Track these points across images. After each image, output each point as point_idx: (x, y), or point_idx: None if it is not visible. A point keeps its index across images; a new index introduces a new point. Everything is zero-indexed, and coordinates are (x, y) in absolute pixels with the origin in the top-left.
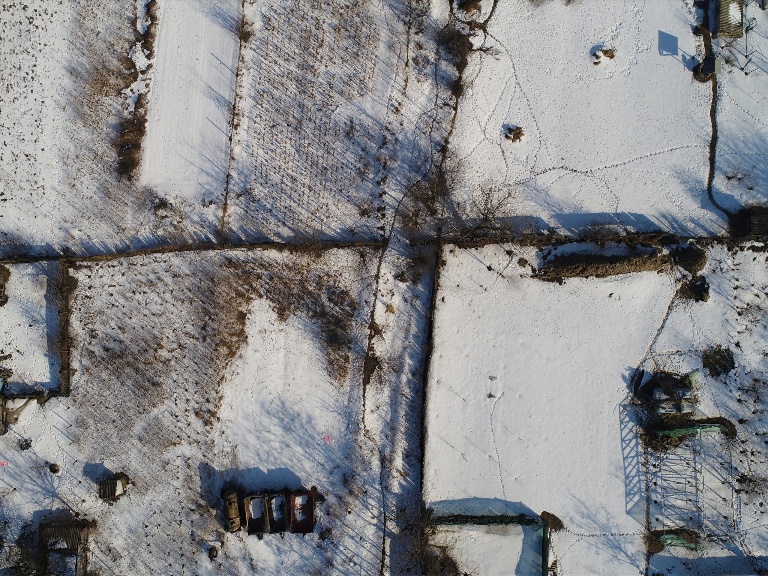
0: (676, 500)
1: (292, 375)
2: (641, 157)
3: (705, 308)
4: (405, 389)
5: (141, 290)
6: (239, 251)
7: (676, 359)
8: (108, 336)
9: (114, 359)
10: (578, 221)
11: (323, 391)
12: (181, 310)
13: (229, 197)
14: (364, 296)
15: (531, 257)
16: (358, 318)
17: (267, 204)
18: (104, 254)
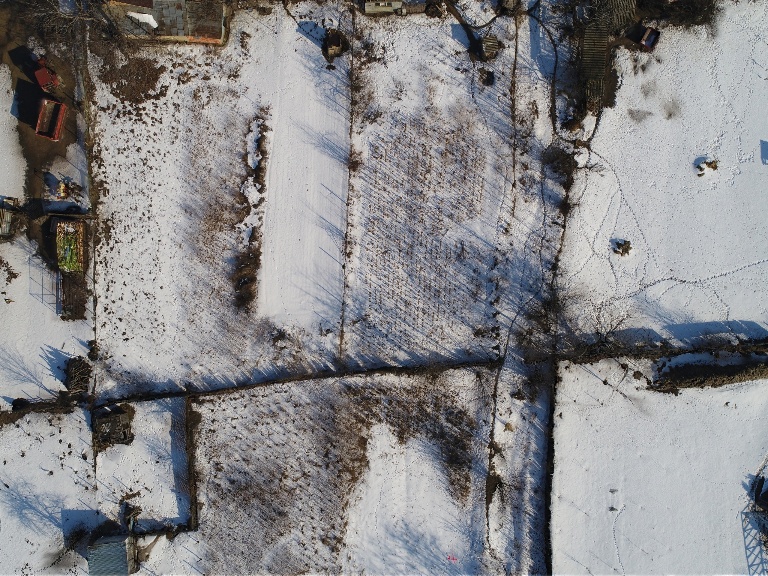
0: None
1: (414, 497)
2: (749, 265)
3: None
4: (528, 507)
5: (263, 421)
6: (358, 377)
7: None
8: (233, 468)
9: (240, 491)
10: (690, 331)
11: (446, 511)
12: (303, 439)
13: (345, 324)
14: (482, 416)
15: (646, 370)
16: (477, 438)
17: (383, 329)
18: (226, 387)
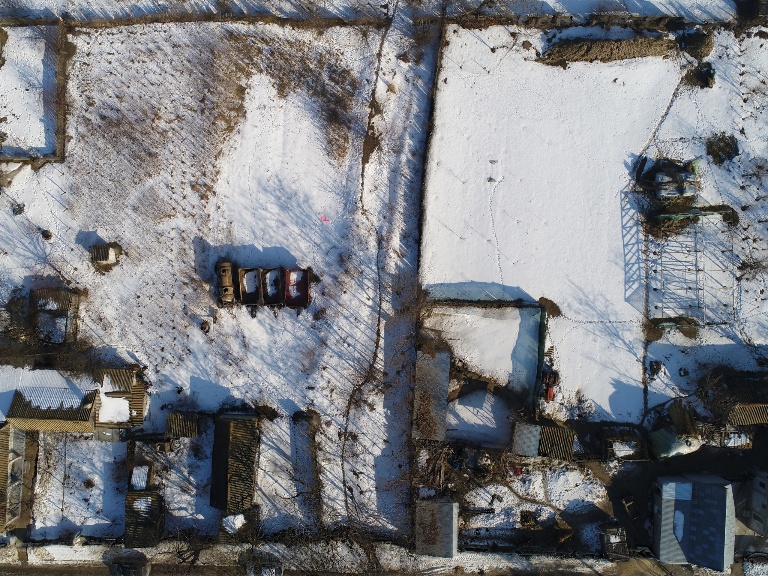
0: (676, 287)
1: (290, 153)
2: None
3: (710, 95)
4: (404, 169)
5: (140, 59)
6: (240, 24)
7: (679, 146)
8: (105, 104)
9: (111, 128)
10: (584, 6)
11: (321, 171)
12: (180, 81)
13: None
14: (365, 75)
15: (535, 40)
16: (359, 97)
17: None
18: (104, 21)
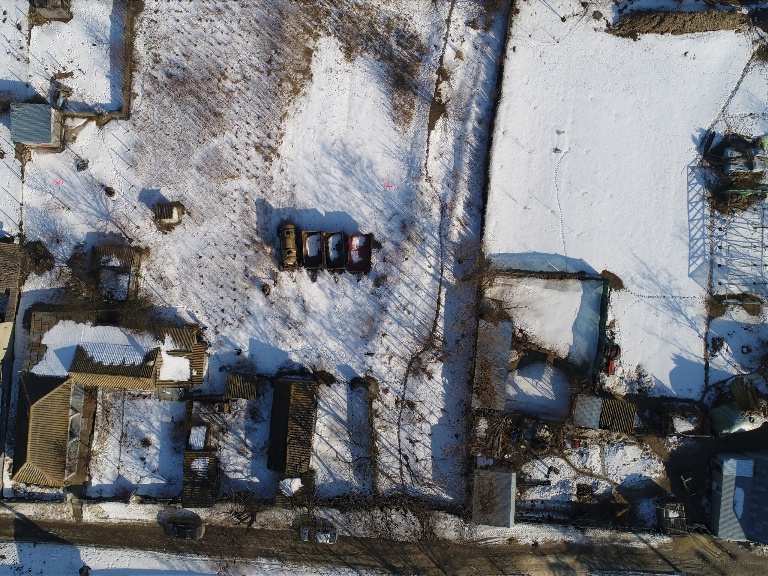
0: (741, 264)
1: (355, 118)
2: None
3: None
4: (470, 137)
5: (208, 18)
6: None
7: (749, 121)
8: (172, 62)
9: (176, 86)
10: None
11: (386, 136)
12: (247, 41)
13: None
14: (434, 41)
15: (606, 10)
16: (426, 63)
17: None
18: None
